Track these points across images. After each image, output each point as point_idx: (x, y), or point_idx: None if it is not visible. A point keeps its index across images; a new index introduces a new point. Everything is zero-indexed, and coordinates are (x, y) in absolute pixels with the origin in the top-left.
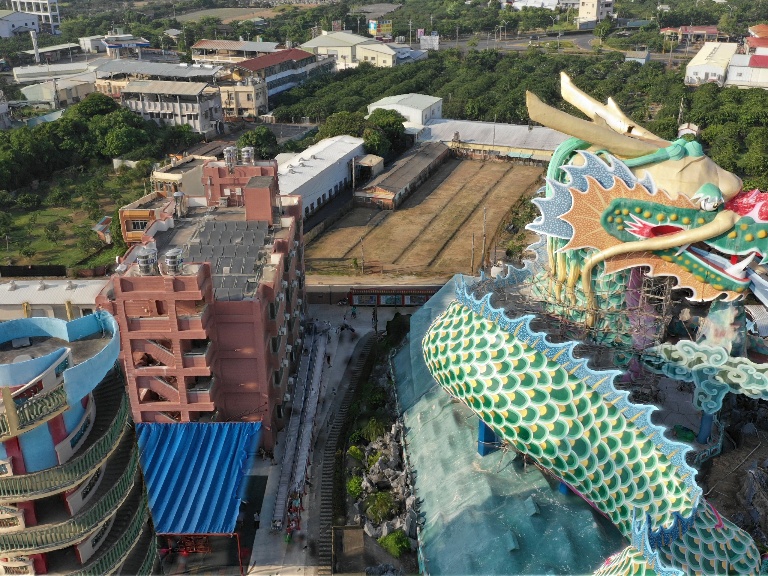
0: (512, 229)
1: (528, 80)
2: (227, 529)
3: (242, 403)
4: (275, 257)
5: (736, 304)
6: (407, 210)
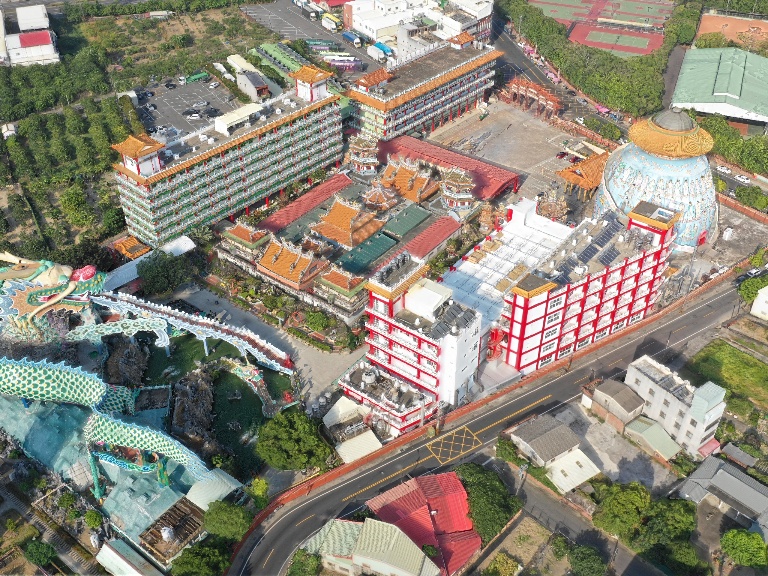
0: None
1: None
2: None
3: None
4: None
5: (90, 307)
6: None
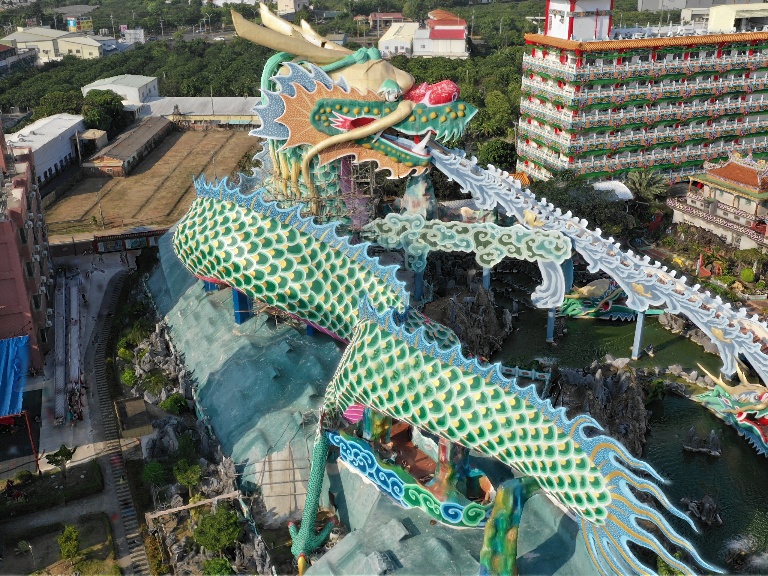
0: None
1: (238, 62)
2: (14, 412)
3: (5, 326)
4: (16, 192)
5: (425, 178)
6: (138, 175)
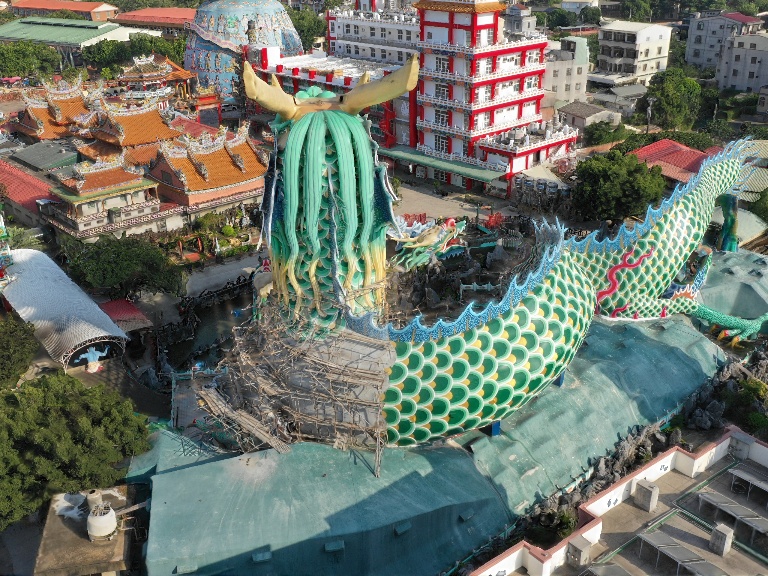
0: None
1: None
2: None
3: None
4: None
5: None
6: None
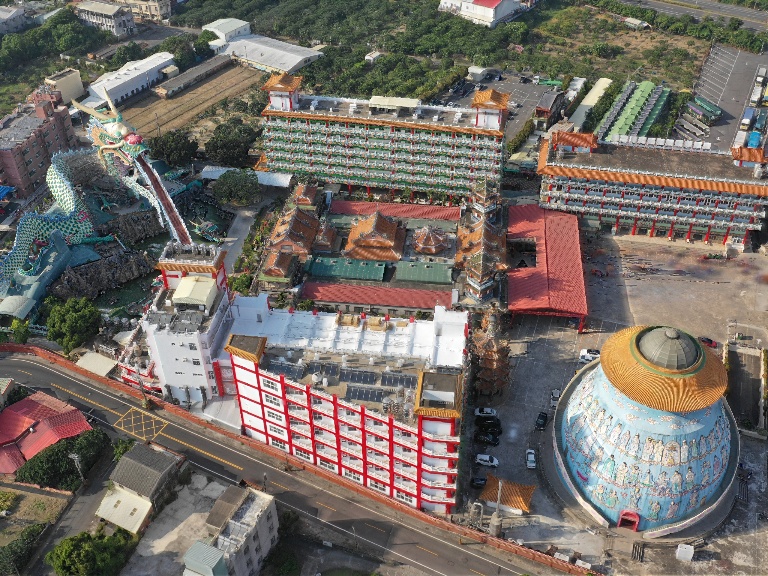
0: (201, 117)
1: None
2: None
3: (15, 181)
4: None
5: None
6: (172, 100)
